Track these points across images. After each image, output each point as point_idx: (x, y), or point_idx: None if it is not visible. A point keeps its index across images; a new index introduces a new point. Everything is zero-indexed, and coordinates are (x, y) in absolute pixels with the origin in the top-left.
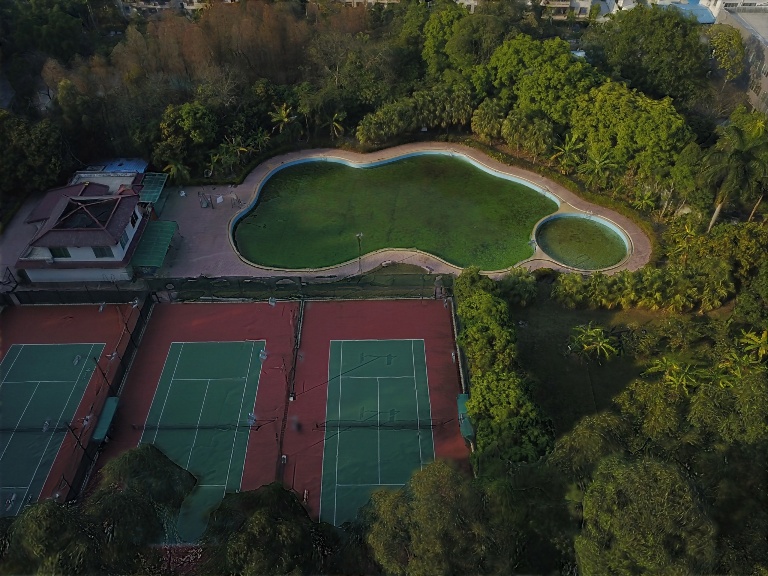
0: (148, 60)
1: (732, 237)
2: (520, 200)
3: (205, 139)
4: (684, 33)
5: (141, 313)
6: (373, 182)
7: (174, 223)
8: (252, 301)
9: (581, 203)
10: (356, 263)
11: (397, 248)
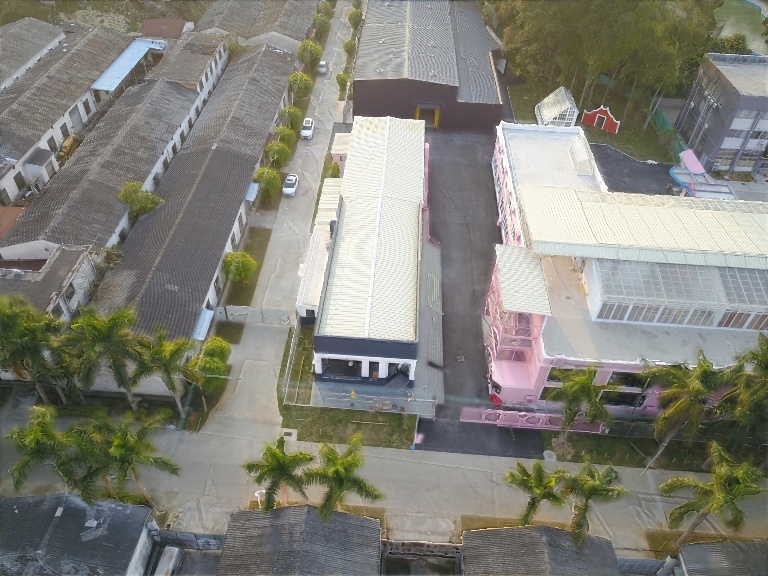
0: None
1: None
2: None
3: None
4: None
5: None
6: (751, 18)
7: None
8: None
9: None
10: None
11: None
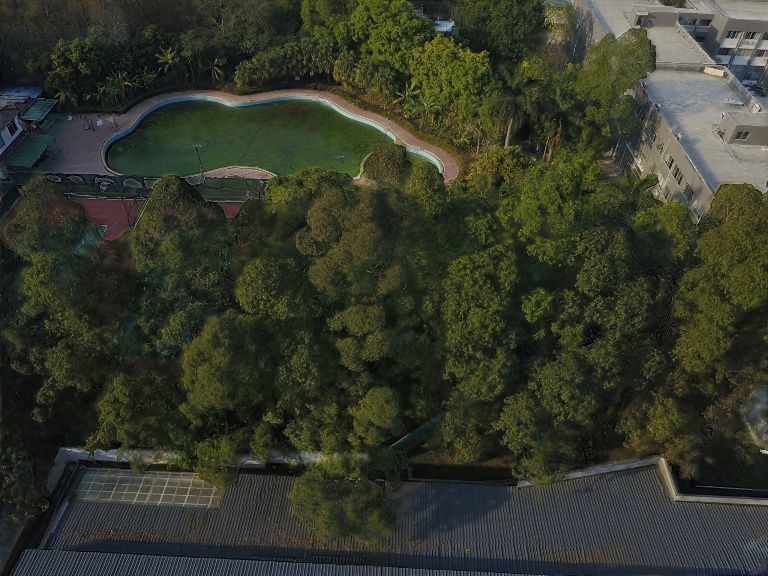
0: (59, 7)
1: (500, 157)
2: (364, 137)
3: (92, 71)
4: (524, 4)
5: (4, 200)
6: (242, 118)
7: (51, 136)
8: (105, 198)
9: (413, 141)
10: (204, 176)
11: (242, 166)
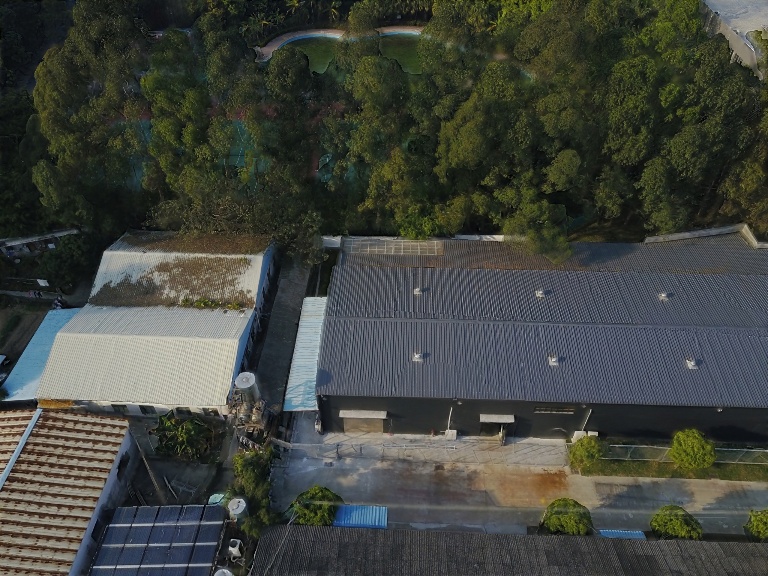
0: None
1: None
2: None
3: (239, 12)
4: None
5: None
6: None
7: None
8: None
9: None
10: None
11: None
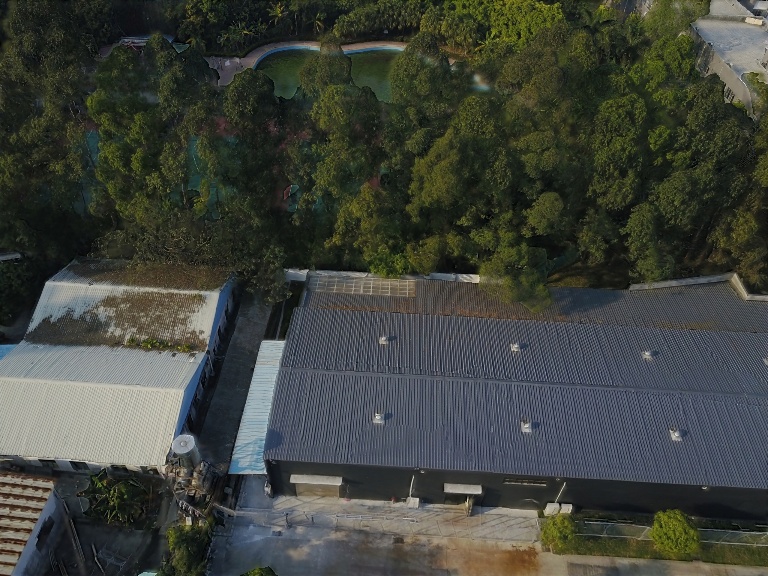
0: None
1: None
2: None
3: (218, 20)
4: None
5: None
6: None
7: None
8: None
9: None
10: None
11: None
